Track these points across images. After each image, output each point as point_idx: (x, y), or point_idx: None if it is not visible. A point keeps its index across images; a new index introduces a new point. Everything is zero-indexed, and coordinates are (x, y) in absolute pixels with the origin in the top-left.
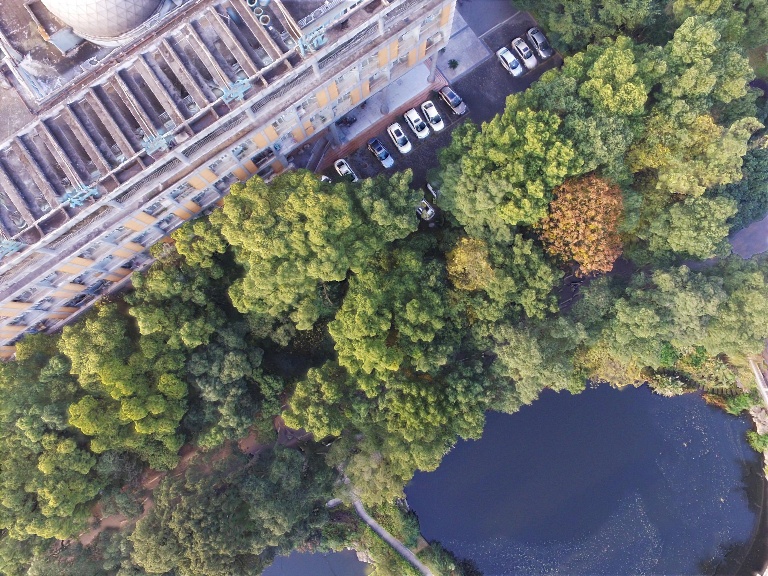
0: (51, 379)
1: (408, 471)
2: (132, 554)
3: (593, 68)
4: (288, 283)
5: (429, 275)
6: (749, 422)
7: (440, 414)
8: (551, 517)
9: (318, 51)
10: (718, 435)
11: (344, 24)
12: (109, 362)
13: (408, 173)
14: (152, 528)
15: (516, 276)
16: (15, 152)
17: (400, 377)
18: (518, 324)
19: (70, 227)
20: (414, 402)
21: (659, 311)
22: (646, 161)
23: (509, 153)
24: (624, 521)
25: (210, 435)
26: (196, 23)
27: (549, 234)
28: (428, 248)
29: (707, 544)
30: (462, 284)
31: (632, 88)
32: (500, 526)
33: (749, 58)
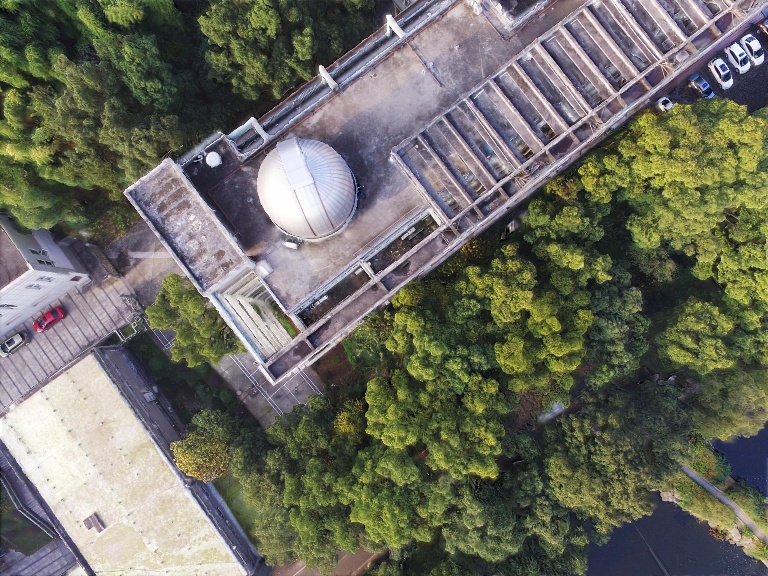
0: (466, 320)
1: None
2: (549, 490)
3: None
4: (707, 213)
5: None
6: None
7: None
8: None
9: None
10: None
11: None
12: (540, 298)
13: None
14: (569, 464)
15: None
16: (512, 77)
17: None
18: None
19: None
20: None
21: None
22: None
23: None
24: None
25: (602, 372)
26: None
27: None
28: None
29: None
30: None
31: None
32: None
33: None
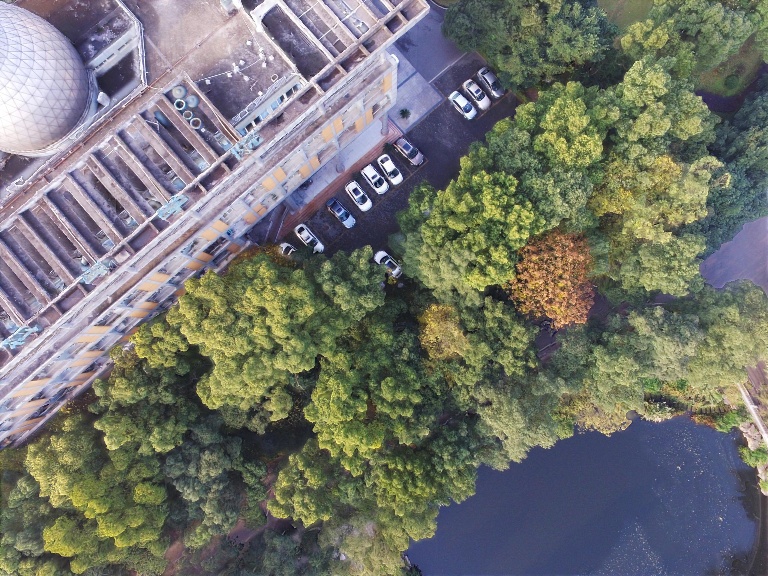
0: (21, 503)
1: (403, 542)
2: None
3: (546, 119)
4: (256, 377)
5: (401, 347)
6: (740, 438)
7: (428, 486)
8: (554, 556)
9: (255, 151)
10: (711, 454)
11: (280, 118)
12: (78, 482)
13: (367, 250)
14: None
15: (490, 339)
16: None
17: (384, 451)
18: (498, 382)
19: (15, 364)
20: (401, 476)
21: (638, 354)
22: (609, 208)
23: (468, 221)
24: (626, 551)
25: (195, 535)
26: (124, 133)
27: (519, 293)
28: (399, 314)
29: (710, 564)
30: (436, 354)
31: (587, 140)
32: (504, 571)
33: (704, 74)
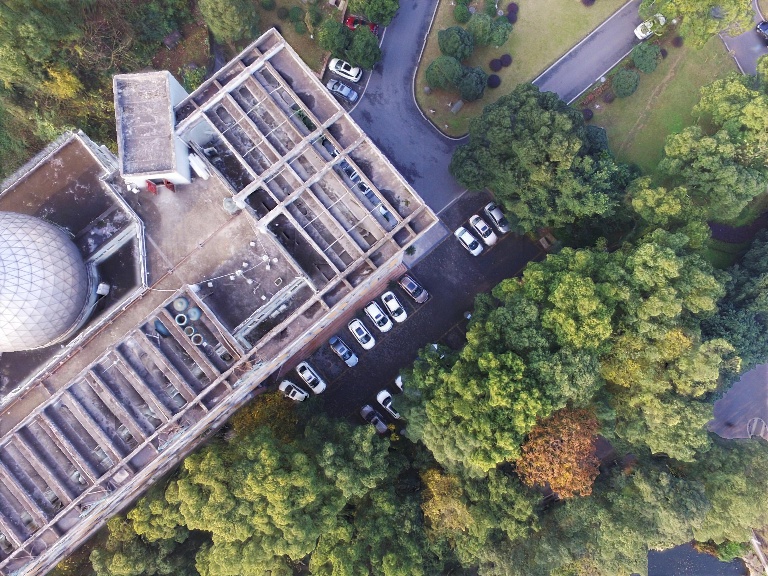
0: None
1: None
2: None
3: (554, 292)
4: None
5: (404, 516)
6: (742, 567)
7: None
8: None
9: (258, 369)
10: None
11: (283, 333)
12: None
13: (370, 431)
14: None
15: (493, 510)
16: None
17: None
18: (500, 544)
19: None
20: None
21: (643, 519)
22: (617, 380)
23: (474, 406)
24: None
25: None
26: (123, 346)
27: (523, 466)
28: (401, 470)
29: None
30: (438, 527)
31: (596, 323)
32: None
33: None
